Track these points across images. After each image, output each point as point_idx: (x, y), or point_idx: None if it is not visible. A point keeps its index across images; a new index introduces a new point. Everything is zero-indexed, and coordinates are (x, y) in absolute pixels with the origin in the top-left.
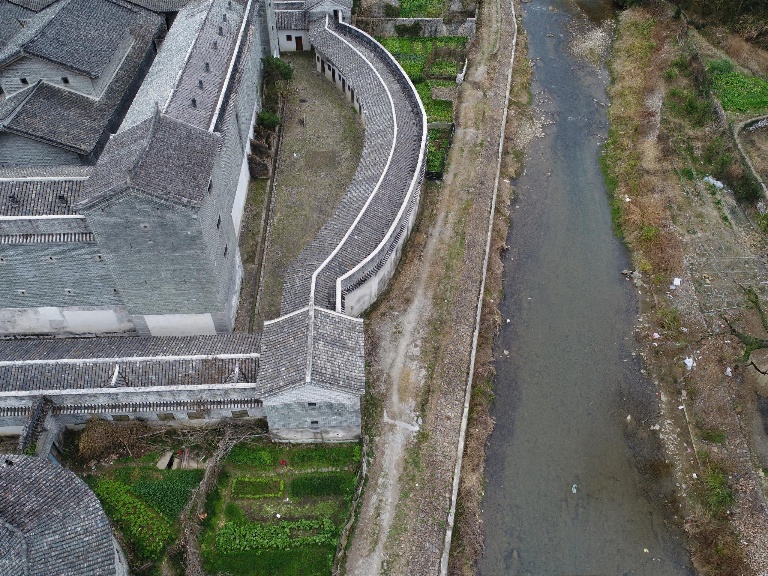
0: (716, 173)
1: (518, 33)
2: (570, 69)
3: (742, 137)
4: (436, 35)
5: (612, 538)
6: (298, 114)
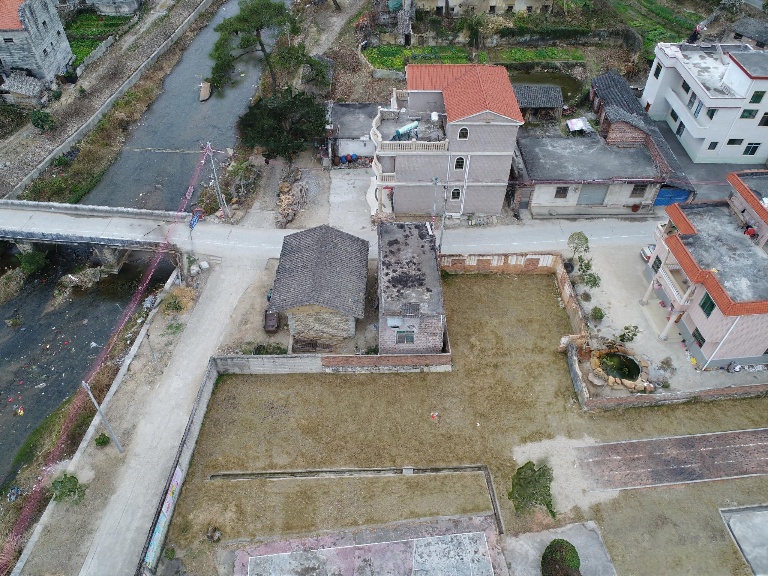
0: None
1: None
2: None
3: None
4: None
5: None
6: None
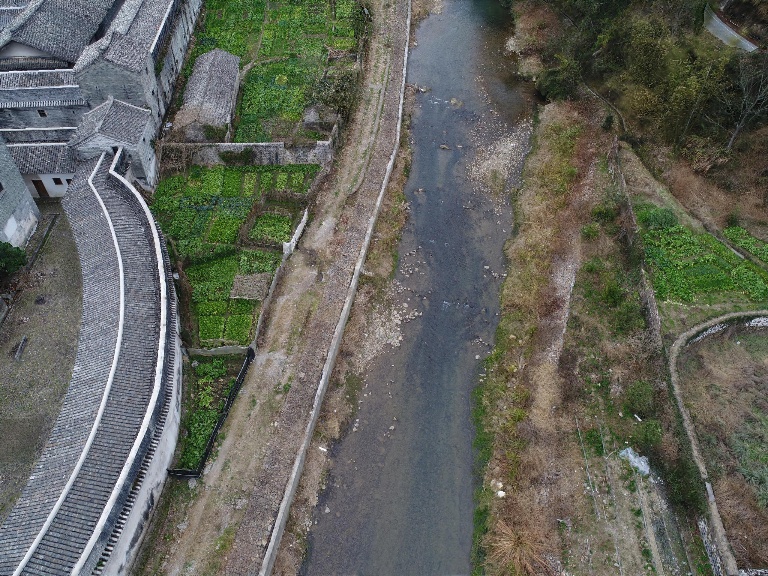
0: None
1: (401, 146)
2: (461, 208)
3: (684, 351)
4: (278, 162)
5: None
6: (21, 331)
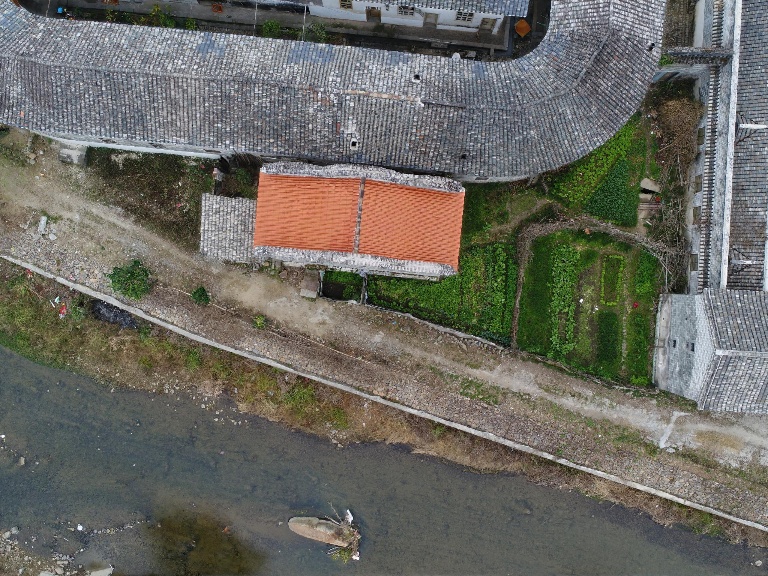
0: None
1: None
2: None
3: None
4: None
5: None
6: None
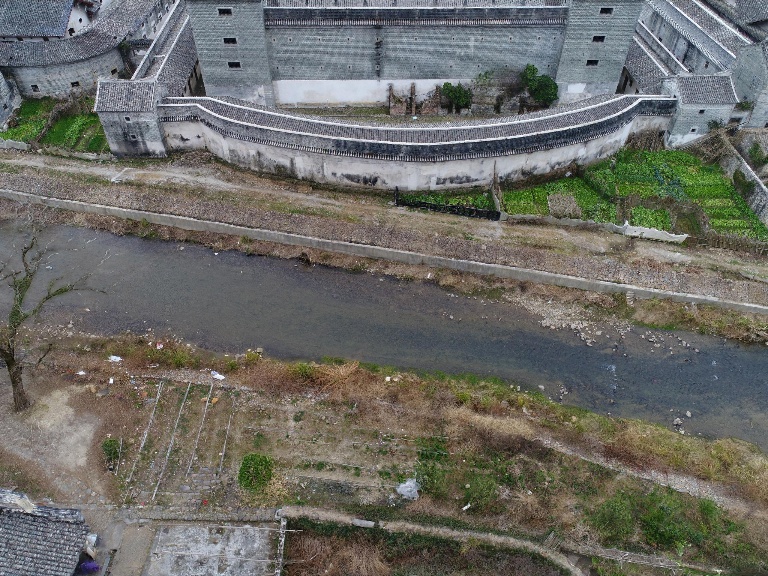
0: (440, 499)
1: None
2: None
3: None
4: (760, 215)
5: (6, 280)
6: None
